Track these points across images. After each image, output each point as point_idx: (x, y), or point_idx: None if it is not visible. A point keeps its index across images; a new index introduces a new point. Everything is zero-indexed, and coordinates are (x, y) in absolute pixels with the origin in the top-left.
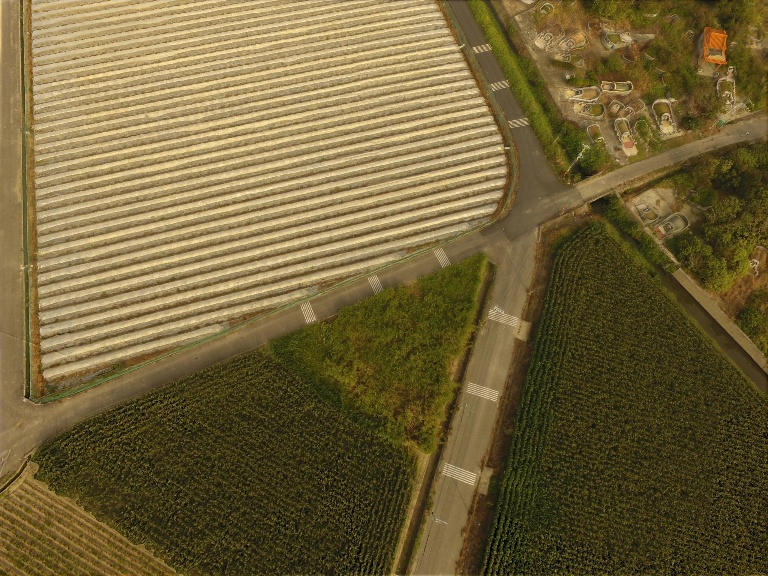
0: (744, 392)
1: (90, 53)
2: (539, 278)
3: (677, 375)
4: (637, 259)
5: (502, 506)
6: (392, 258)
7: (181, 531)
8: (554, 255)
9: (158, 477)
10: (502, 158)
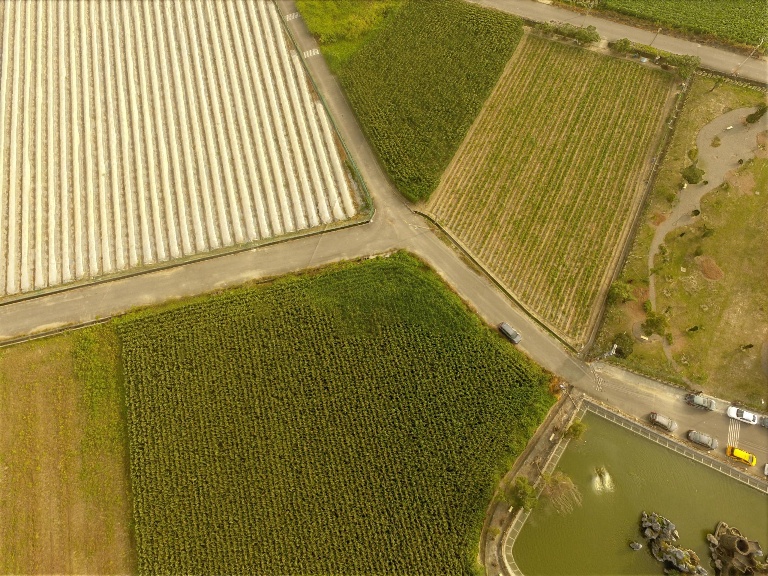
0: None
1: (2, 241)
2: None
3: None
4: None
5: None
6: (273, 6)
7: None
8: None
9: None
10: None
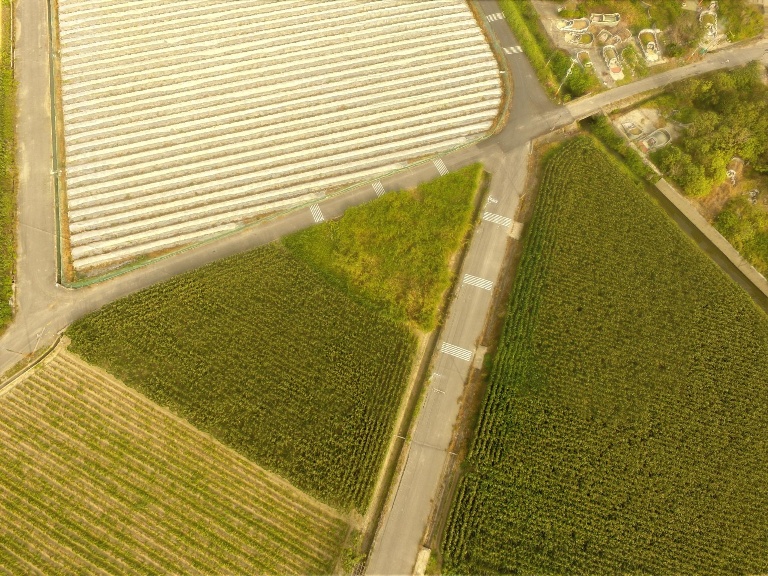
0: (719, 282)
1: None
2: (531, 185)
3: (657, 267)
4: (622, 169)
5: (495, 376)
6: (394, 167)
7: (202, 395)
8: (545, 165)
9: (180, 349)
10: (497, 81)
